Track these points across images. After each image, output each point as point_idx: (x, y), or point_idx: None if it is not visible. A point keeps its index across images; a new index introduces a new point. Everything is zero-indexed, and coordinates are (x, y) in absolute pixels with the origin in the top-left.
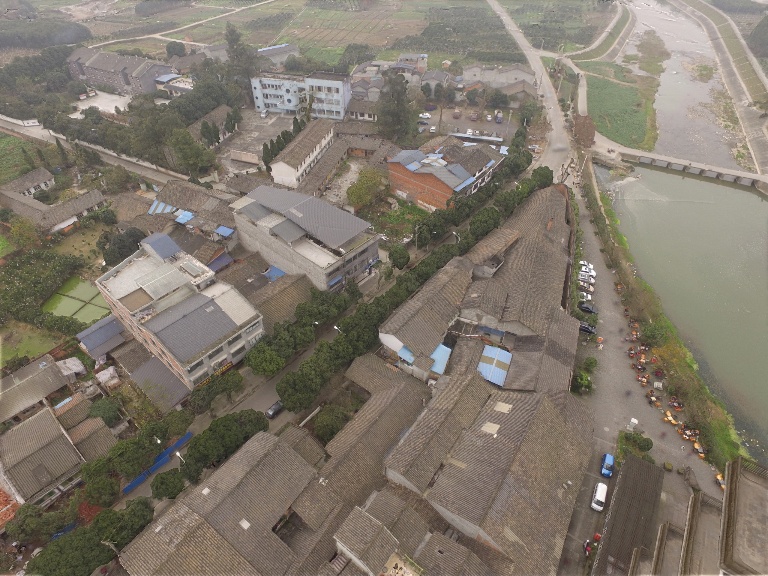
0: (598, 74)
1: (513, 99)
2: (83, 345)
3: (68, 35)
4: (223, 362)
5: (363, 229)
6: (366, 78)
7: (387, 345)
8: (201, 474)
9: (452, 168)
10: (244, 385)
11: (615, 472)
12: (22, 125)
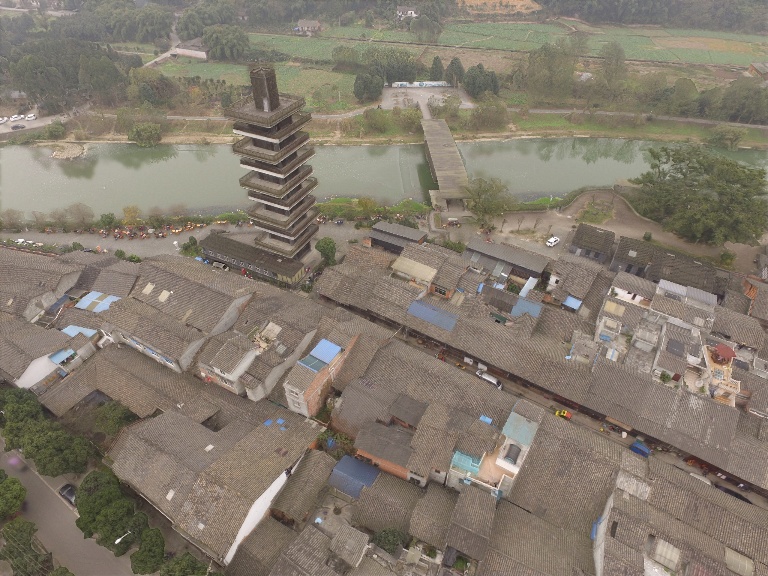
0: None
1: None
2: None
3: None
4: None
5: None
6: None
7: (34, 383)
8: None
9: None
10: None
11: None
12: None
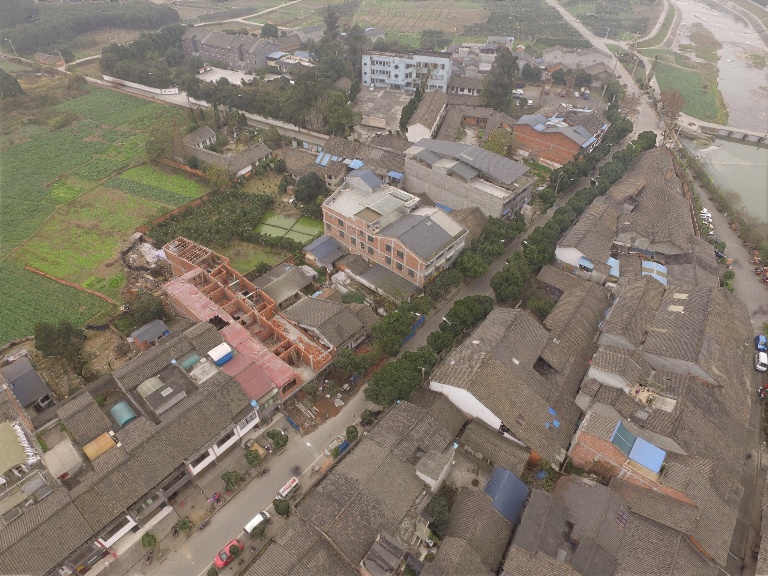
0: (661, 60)
1: (596, 78)
2: (310, 257)
3: (162, 17)
4: (440, 266)
5: (525, 171)
6: (458, 58)
7: (561, 259)
8: (455, 338)
9: (577, 128)
10: (450, 288)
11: (767, 348)
12: (159, 93)
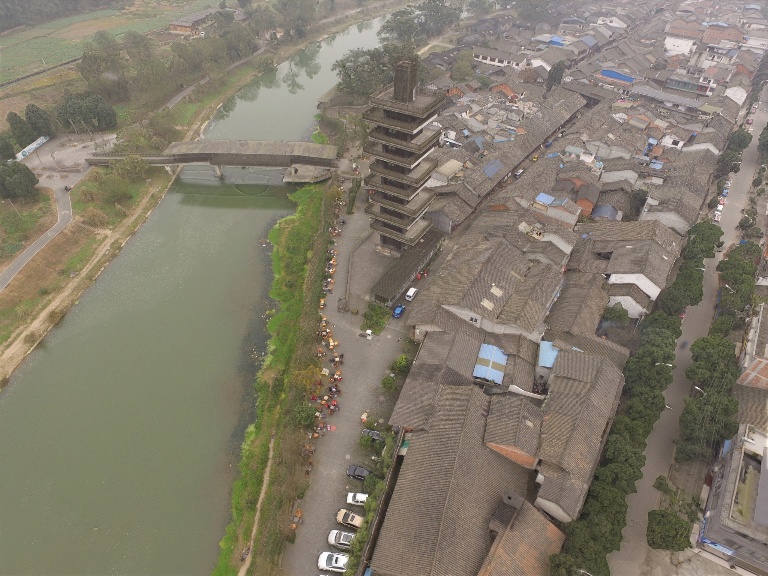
0: None
1: None
2: None
3: None
4: None
5: (759, 503)
6: None
7: None
8: None
9: None
10: None
11: None
12: None
